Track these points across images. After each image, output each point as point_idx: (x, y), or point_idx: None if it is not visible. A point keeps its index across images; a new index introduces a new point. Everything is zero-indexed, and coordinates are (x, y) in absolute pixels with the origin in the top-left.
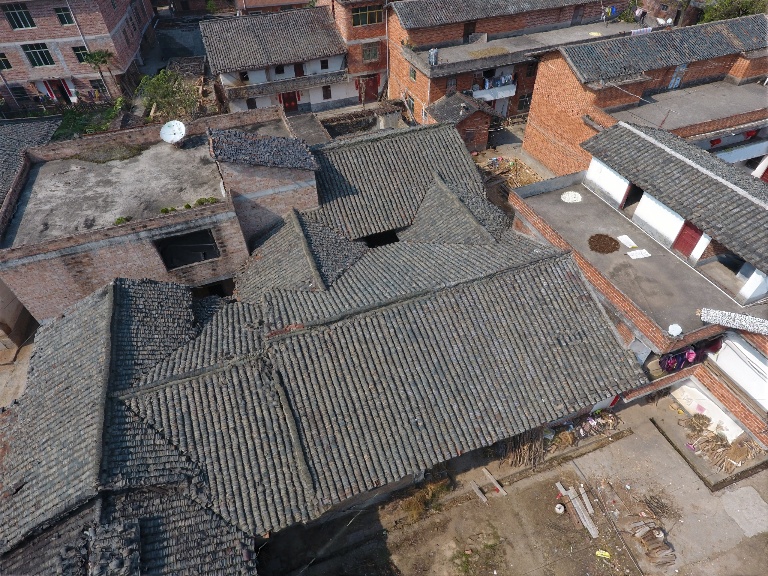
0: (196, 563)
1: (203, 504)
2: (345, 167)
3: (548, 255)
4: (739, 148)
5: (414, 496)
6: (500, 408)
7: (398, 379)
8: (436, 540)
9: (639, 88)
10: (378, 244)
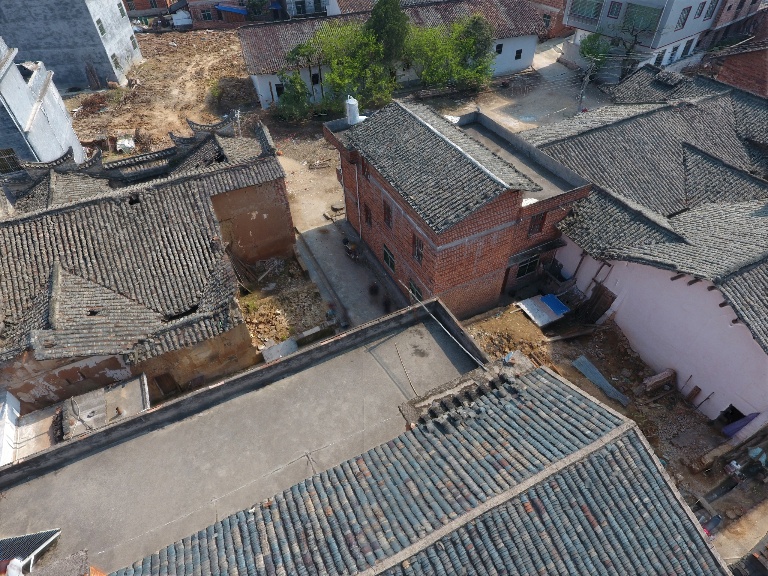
0: None
1: None
2: None
3: (546, 142)
4: None
5: None
6: None
7: None
8: None
9: None
10: (683, 210)
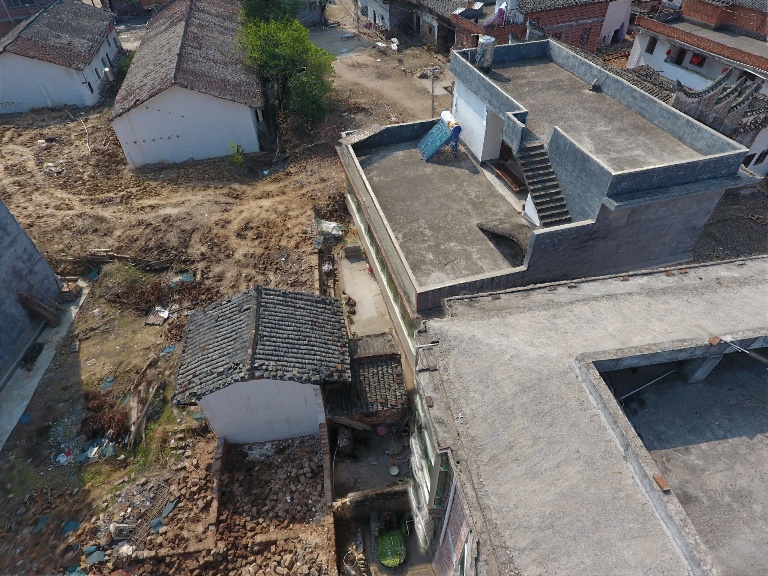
0: None
1: None
2: None
3: None
4: None
5: (430, 44)
6: (446, 8)
7: None
8: (419, 51)
9: (716, 12)
10: None
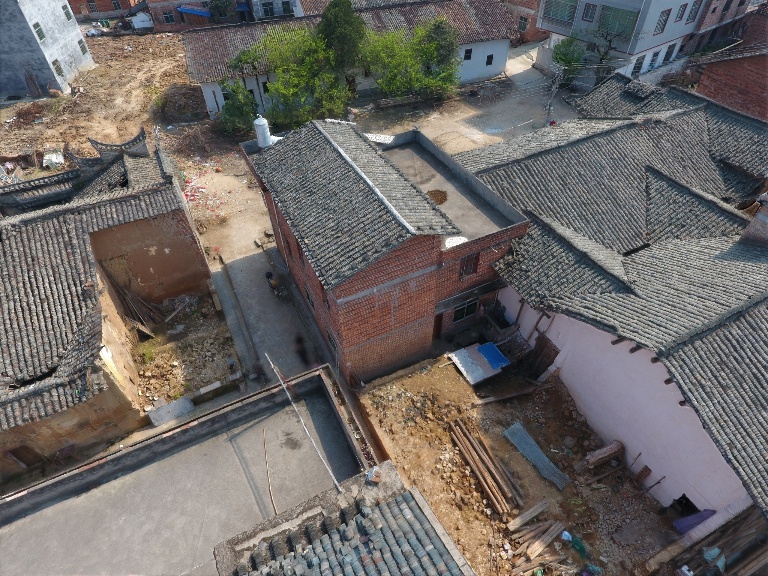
0: None
1: None
2: (760, 268)
3: (486, 168)
4: None
5: None
6: None
7: None
8: None
9: None
10: None
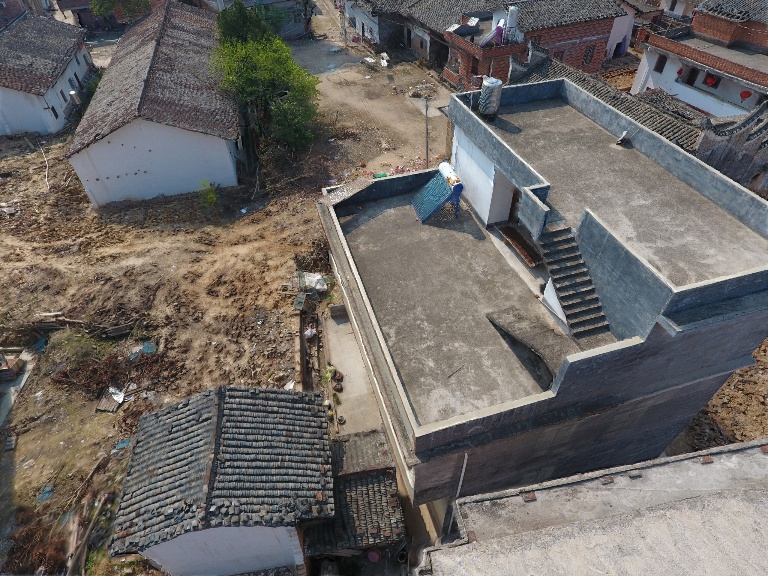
0: (390, 2)
1: (403, 1)
2: None
3: None
4: (731, 104)
5: (422, 59)
6: None
7: (442, 4)
8: None
9: (730, 28)
10: None
